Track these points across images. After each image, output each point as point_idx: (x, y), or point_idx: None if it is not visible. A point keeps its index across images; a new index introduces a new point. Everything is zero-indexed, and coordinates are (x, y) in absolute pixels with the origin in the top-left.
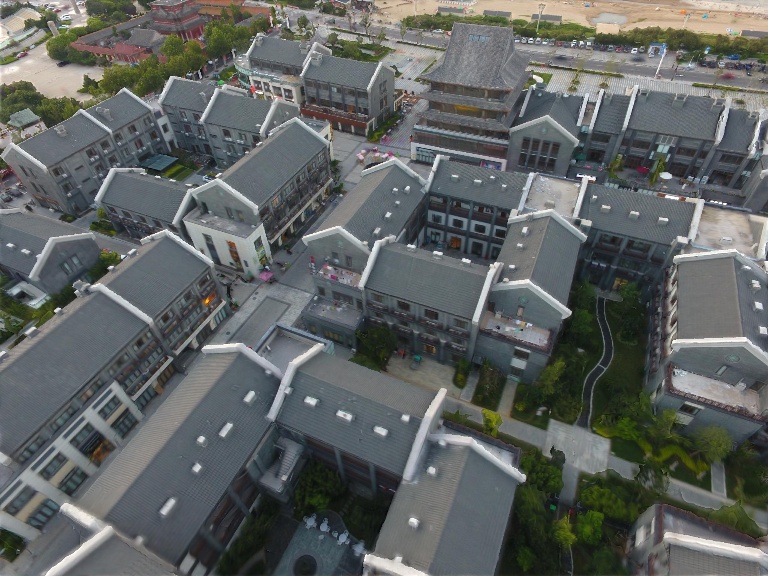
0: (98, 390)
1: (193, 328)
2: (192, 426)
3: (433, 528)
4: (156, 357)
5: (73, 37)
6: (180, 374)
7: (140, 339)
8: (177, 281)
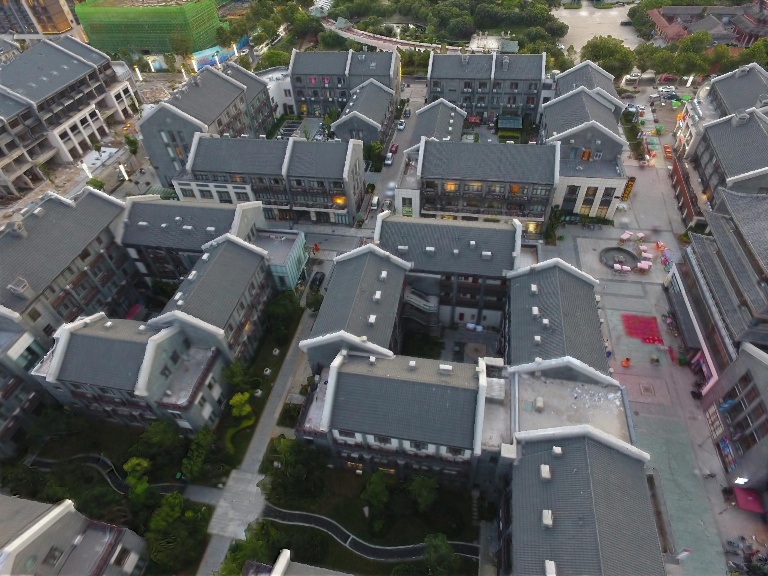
0: (241, 182)
1: (314, 205)
2: (186, 212)
3: (100, 333)
4: (284, 199)
5: (666, 4)
6: (292, 222)
7: (277, 179)
8: (320, 170)
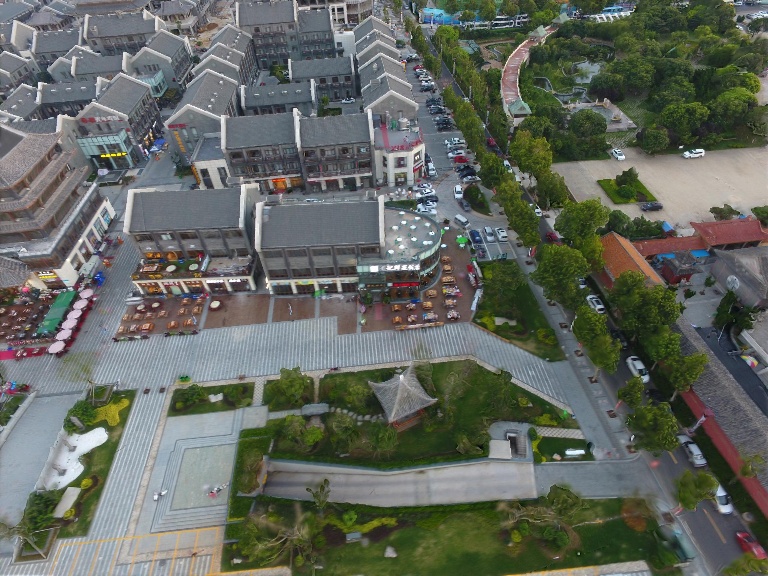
0: None
1: None
2: None
3: None
4: None
5: None
6: None
7: None
8: None
